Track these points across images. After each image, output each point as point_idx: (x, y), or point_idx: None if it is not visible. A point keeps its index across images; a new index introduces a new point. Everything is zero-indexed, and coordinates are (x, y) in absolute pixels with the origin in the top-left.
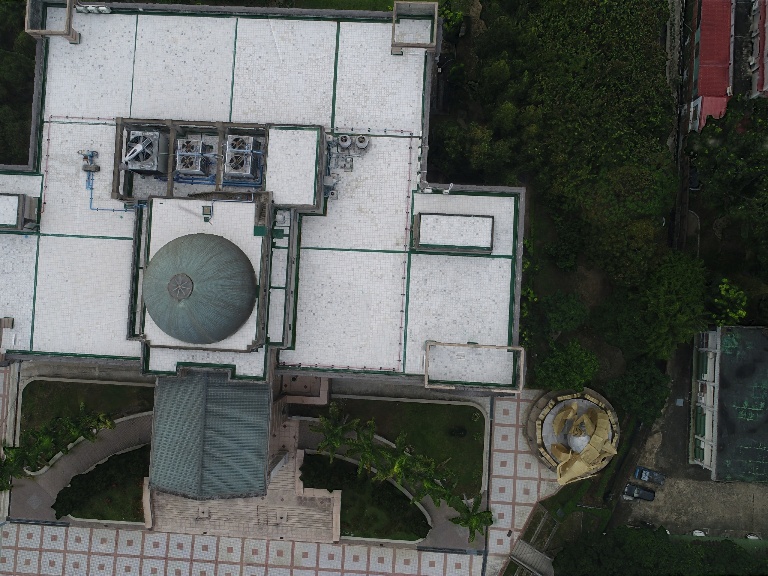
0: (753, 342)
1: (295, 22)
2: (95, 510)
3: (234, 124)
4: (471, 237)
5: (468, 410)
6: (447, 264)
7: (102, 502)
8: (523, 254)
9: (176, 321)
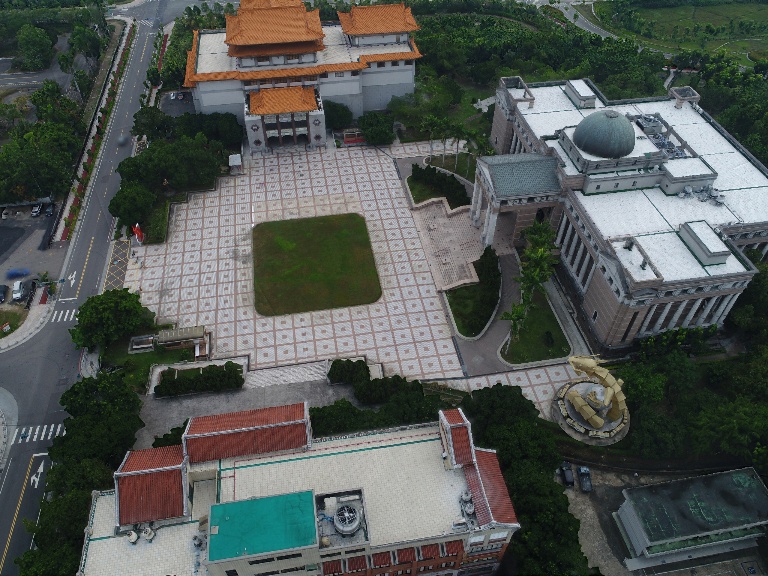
0: (758, 499)
1: (758, 171)
2: (414, 186)
3: (689, 147)
4: (710, 244)
5: (566, 346)
6: (682, 248)
7: (420, 188)
8: (704, 333)
9: (592, 119)
